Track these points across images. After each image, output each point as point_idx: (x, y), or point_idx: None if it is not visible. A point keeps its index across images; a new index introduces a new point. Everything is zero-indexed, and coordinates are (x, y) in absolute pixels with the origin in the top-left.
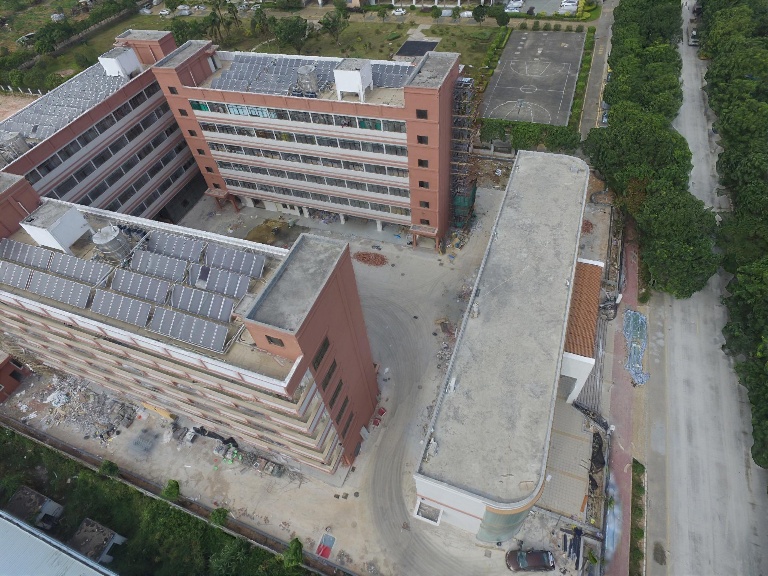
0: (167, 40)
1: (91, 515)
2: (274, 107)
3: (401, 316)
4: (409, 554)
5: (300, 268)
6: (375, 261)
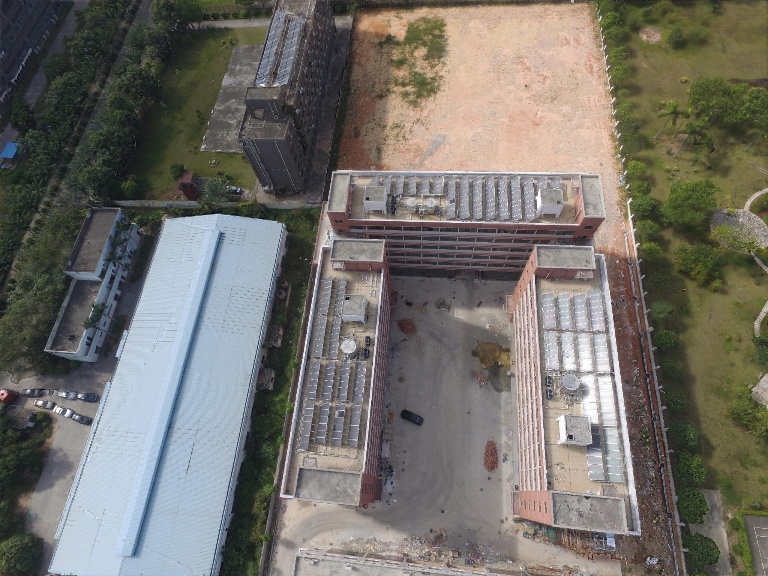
0: (595, 219)
1: (276, 368)
2: (535, 362)
3: (441, 499)
4: (292, 545)
5: (339, 481)
6: (488, 462)
